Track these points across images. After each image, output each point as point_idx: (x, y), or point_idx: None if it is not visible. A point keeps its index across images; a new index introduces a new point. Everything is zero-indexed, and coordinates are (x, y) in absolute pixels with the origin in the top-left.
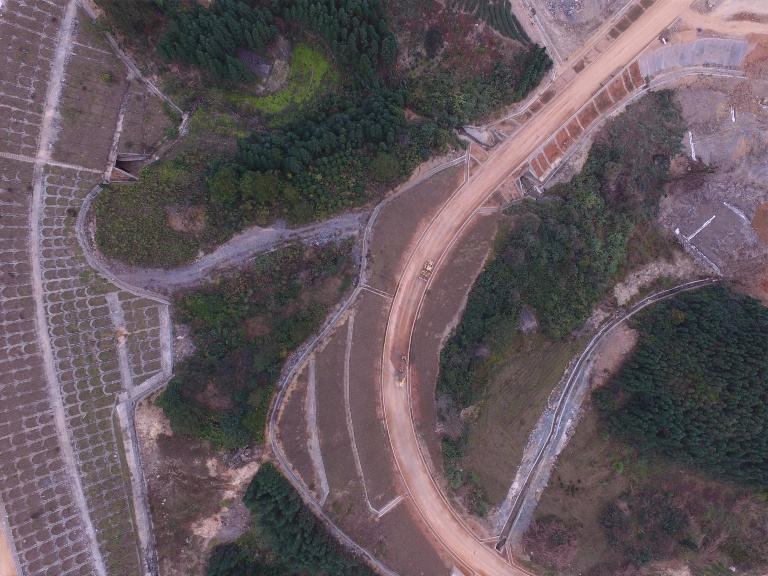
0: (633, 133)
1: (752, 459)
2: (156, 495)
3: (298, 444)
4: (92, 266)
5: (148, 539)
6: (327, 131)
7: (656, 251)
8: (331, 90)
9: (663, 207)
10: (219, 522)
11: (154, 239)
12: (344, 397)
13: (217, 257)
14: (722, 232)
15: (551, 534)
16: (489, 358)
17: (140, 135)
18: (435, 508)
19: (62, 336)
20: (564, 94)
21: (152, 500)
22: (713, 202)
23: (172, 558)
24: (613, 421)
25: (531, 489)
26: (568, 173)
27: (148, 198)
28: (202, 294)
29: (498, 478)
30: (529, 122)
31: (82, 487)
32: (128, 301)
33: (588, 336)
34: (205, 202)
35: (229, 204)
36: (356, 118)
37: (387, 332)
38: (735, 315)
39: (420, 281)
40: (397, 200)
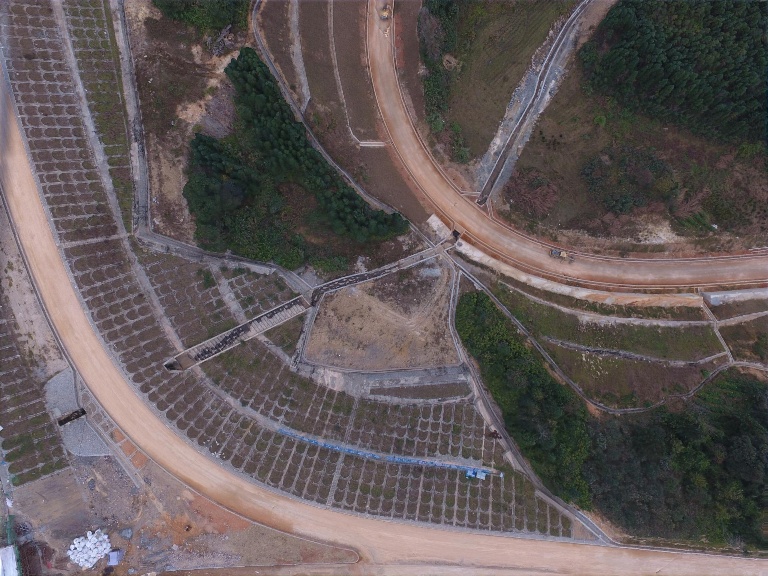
0: None
1: (735, 91)
2: (143, 73)
3: (280, 44)
4: None
5: (135, 114)
6: None
7: None
8: None
9: None
10: (203, 109)
11: None
12: (328, 24)
13: None
14: None
15: (531, 180)
16: (473, 12)
17: None
18: (417, 158)
19: None
20: None
21: (139, 78)
22: None
23: (158, 133)
24: (596, 68)
25: (513, 148)
26: None
27: None
28: None
29: (480, 131)
30: None
31: (73, 49)
32: None
33: None
34: None
35: None
36: None
37: None
38: None
39: None
40: None
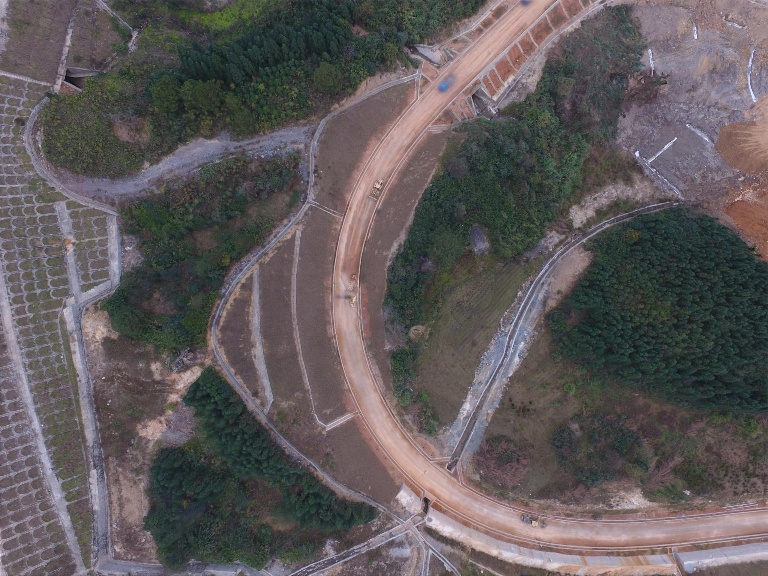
0: (588, 49)
1: (704, 377)
2: (101, 396)
3: (241, 352)
4: (40, 174)
5: (94, 438)
6: (269, 40)
7: (614, 173)
8: (279, 6)
9: (622, 128)
10: (164, 425)
11: (98, 147)
12: (291, 311)
13: (162, 168)
14: (684, 154)
15: (500, 453)
16: (440, 279)
17: (89, 50)
18: (386, 427)
19: (9, 240)
20: (517, 9)
21: (98, 400)
22: (675, 124)
23: (117, 457)
24: (564, 341)
25: (483, 411)
26: (521, 91)
27: (92, 106)
28: (148, 204)
29: (449, 398)
30: (481, 38)
31: (28, 384)
32: (76, 210)
33: (542, 258)
34: (150, 113)
35: (173, 114)
36: (300, 30)
37: (337, 251)
38: (691, 233)
39: (370, 200)
40: (343, 114)
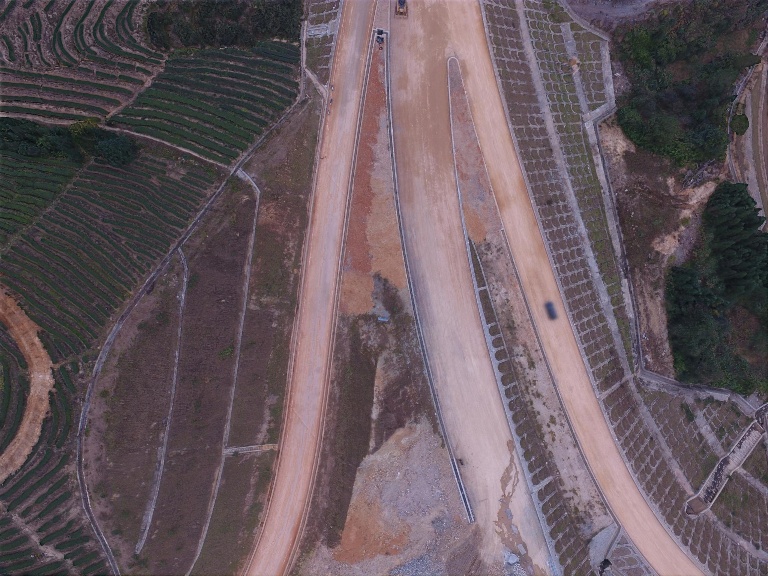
0: None
1: None
2: (625, 208)
3: None
4: None
5: (620, 249)
6: None
7: None
8: None
9: None
10: (676, 240)
11: None
12: (758, 144)
13: None
14: None
15: None
16: None
17: None
18: None
19: (540, 51)
20: None
21: (621, 212)
22: None
23: (642, 268)
24: None
25: None
26: None
27: None
28: None
29: None
30: None
31: (572, 188)
32: (578, 32)
33: None
34: None
35: None
36: None
37: None
38: None
39: None
40: None
